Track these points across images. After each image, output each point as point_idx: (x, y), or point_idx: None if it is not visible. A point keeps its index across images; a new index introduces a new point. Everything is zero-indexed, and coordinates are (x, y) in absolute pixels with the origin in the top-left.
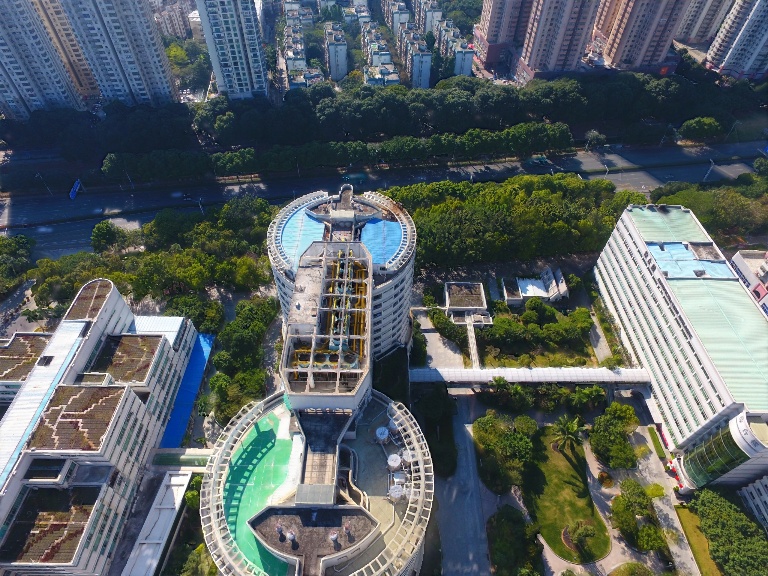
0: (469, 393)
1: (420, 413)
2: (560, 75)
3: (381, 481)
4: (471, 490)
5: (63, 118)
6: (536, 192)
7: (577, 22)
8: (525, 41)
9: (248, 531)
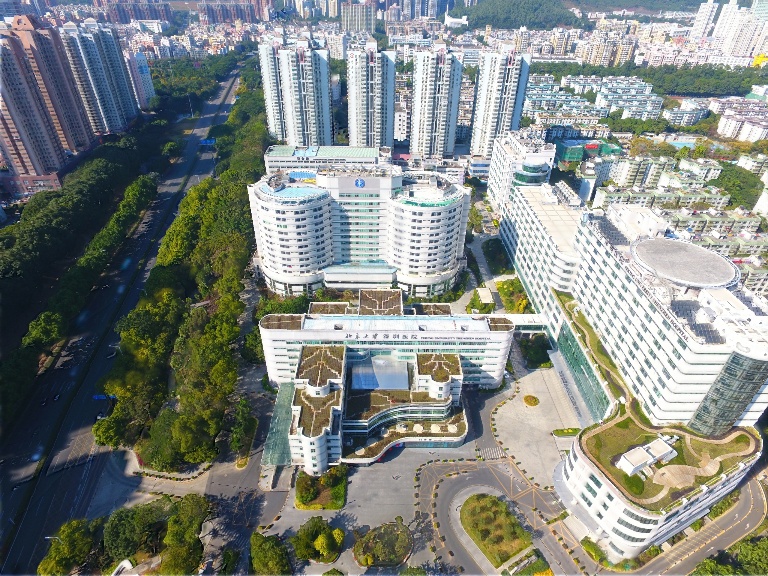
0: None
1: None
2: (67, 169)
3: None
4: None
5: None
6: None
7: (50, 128)
8: (14, 162)
9: (443, 202)
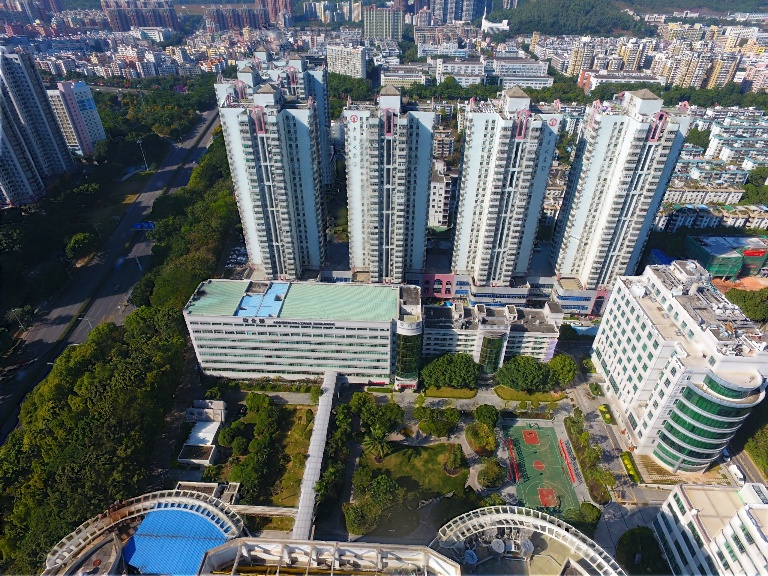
0: (313, 531)
1: None
2: None
3: (514, 568)
4: None
5: None
6: (78, 386)
7: None
8: None
9: None
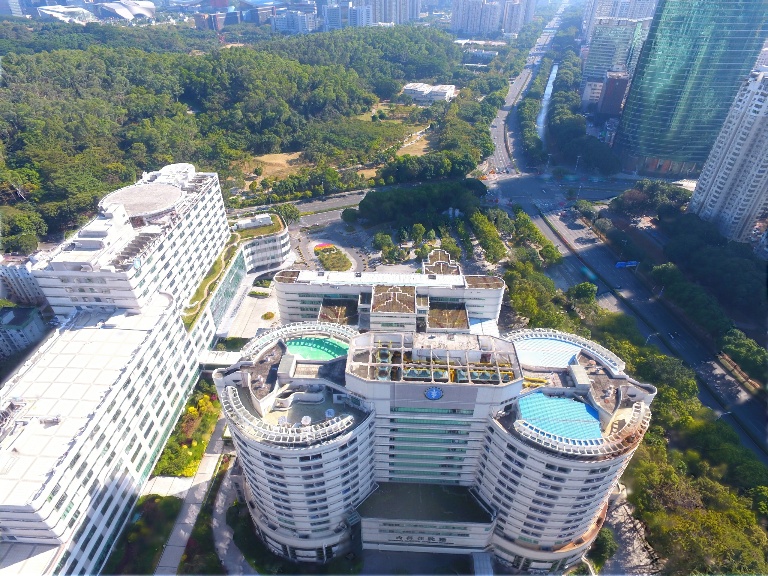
0: None
1: (435, 568)
2: None
3: (297, 419)
4: None
5: (699, 228)
6: None
7: None
8: None
9: None
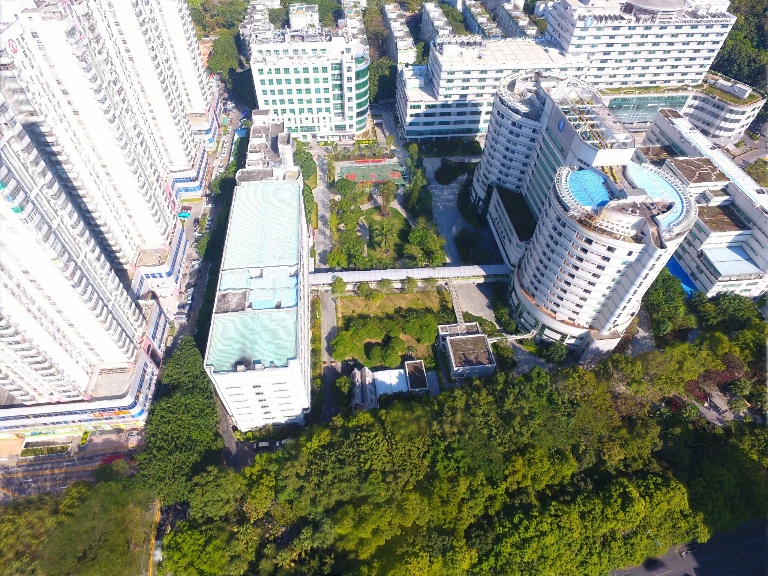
0: None
1: None
2: None
3: None
4: (444, 231)
5: None
6: (380, 535)
7: None
8: None
9: None
